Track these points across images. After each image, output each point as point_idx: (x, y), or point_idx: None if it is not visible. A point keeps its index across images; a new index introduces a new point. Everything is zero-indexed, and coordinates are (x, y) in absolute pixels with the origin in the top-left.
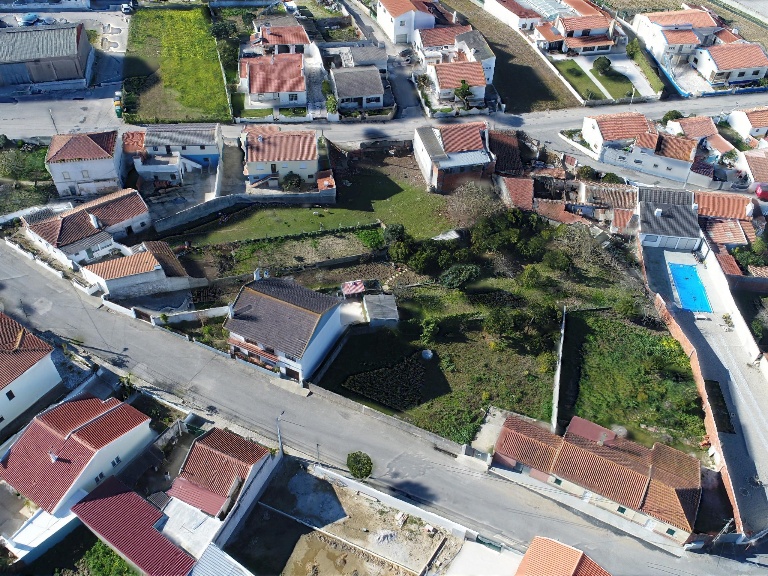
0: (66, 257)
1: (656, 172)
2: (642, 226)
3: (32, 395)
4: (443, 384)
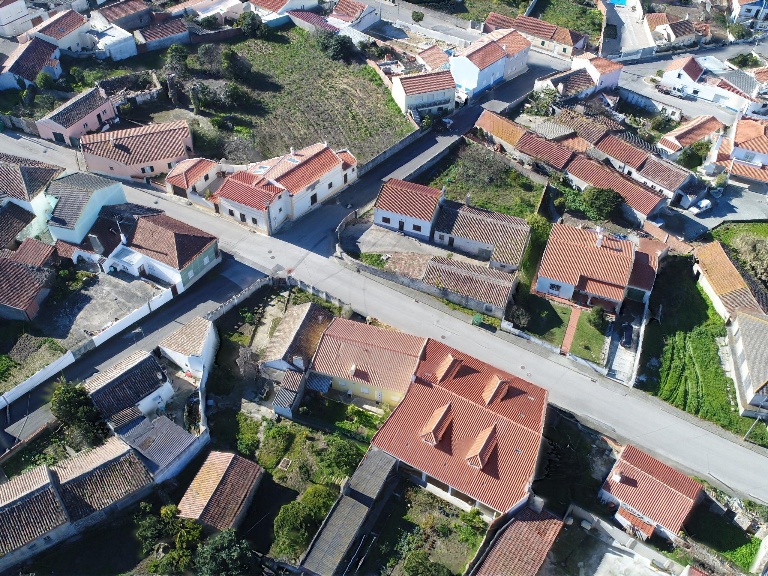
0: None
1: None
2: None
3: None
4: (465, 10)
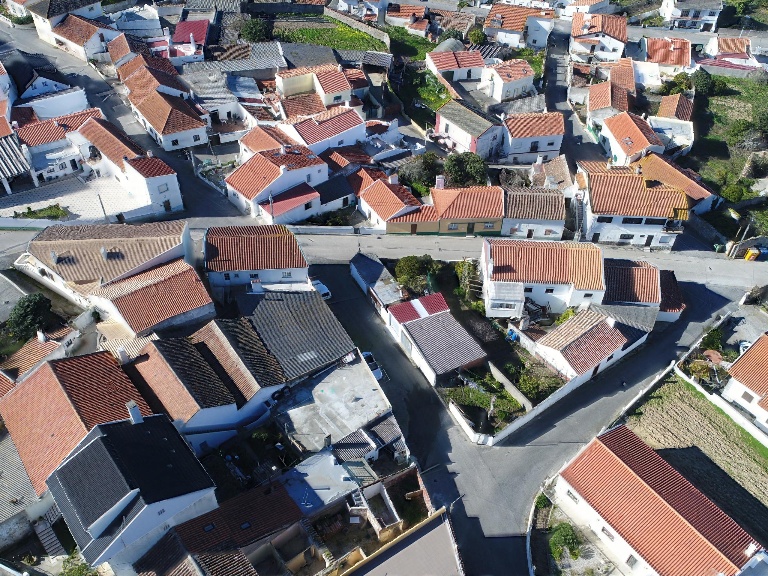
0: (549, 6)
1: None
2: None
3: None
4: (765, 25)
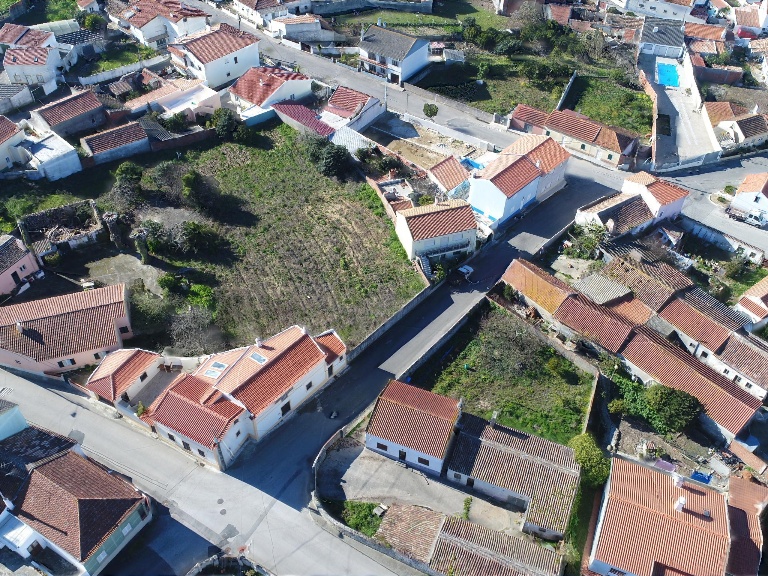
0: (260, 16)
1: (666, 17)
2: (642, 38)
3: (245, 67)
4: (487, 96)
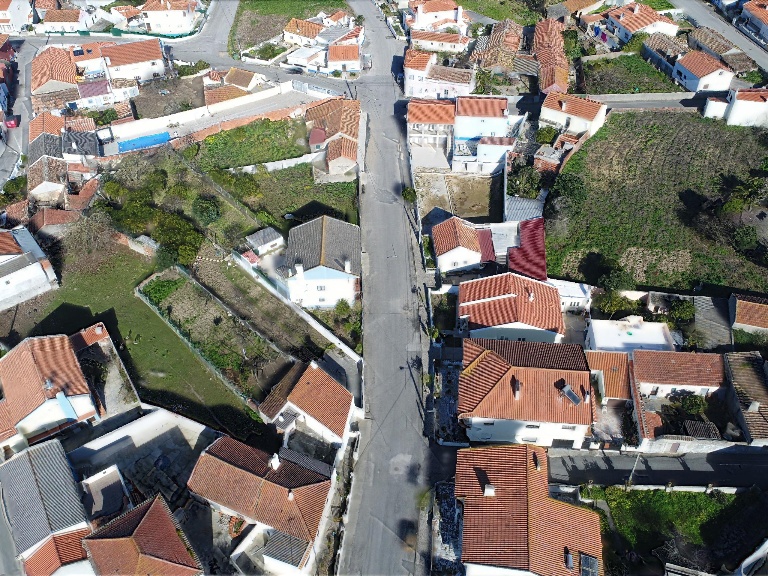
0: None
1: None
2: (91, 155)
3: None
4: (311, 205)
